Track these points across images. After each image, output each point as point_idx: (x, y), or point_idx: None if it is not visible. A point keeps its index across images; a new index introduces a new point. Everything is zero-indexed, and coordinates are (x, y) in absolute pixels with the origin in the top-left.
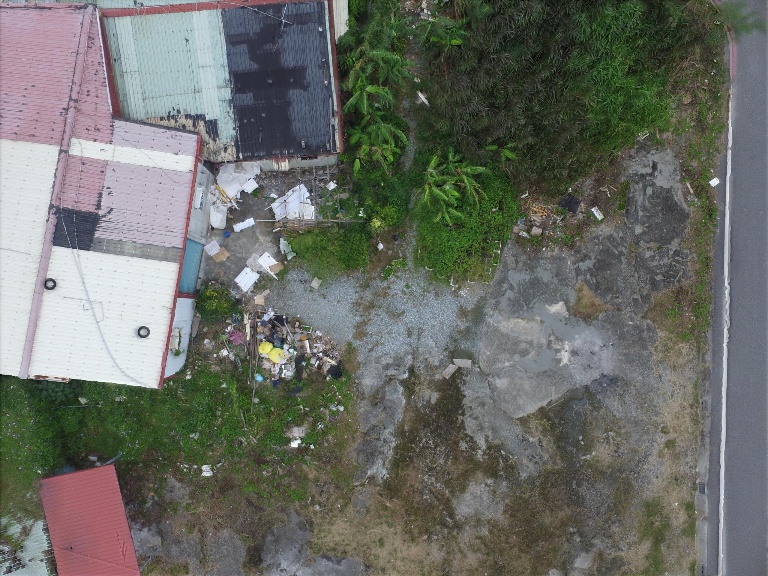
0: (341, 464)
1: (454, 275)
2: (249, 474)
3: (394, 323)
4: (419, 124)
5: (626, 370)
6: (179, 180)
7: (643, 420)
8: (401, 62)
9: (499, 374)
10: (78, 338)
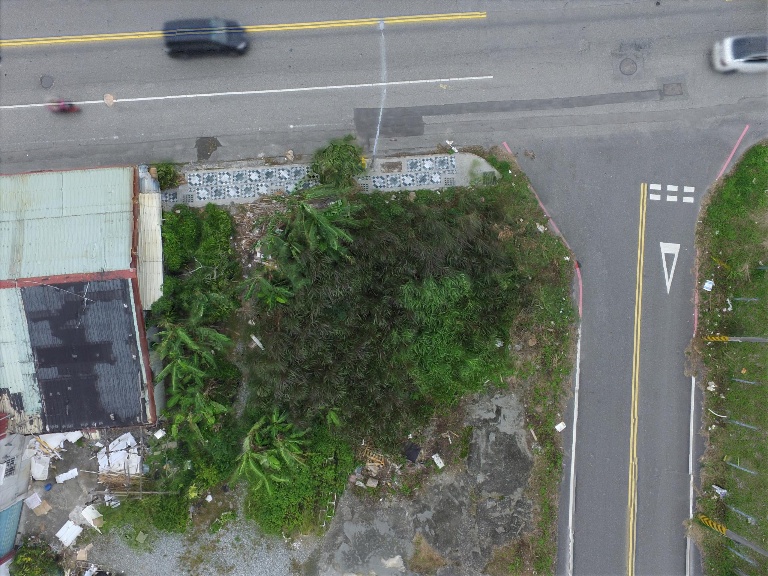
0: None
1: (285, 530)
2: None
3: None
4: (252, 370)
5: None
6: None
7: None
8: (230, 311)
9: None
10: None
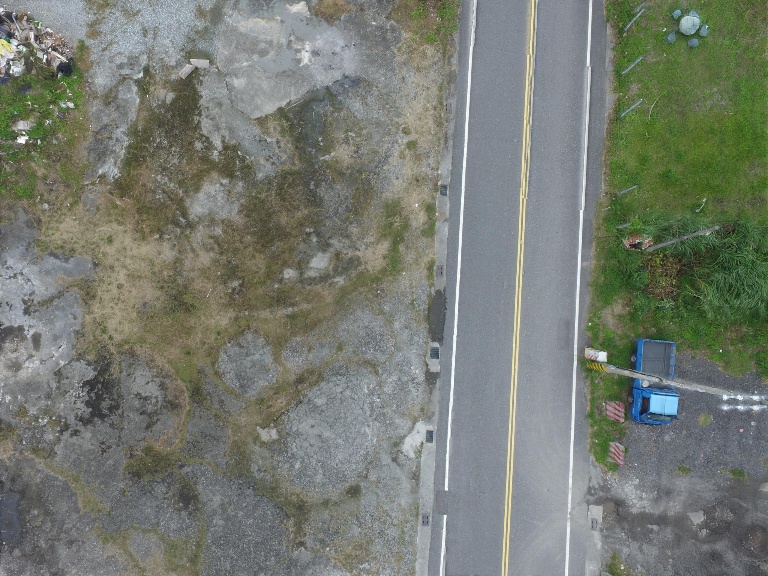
0: (71, 163)
1: None
2: None
3: (129, 22)
4: None
5: (368, 70)
6: None
7: (384, 121)
8: None
9: (237, 74)
10: None
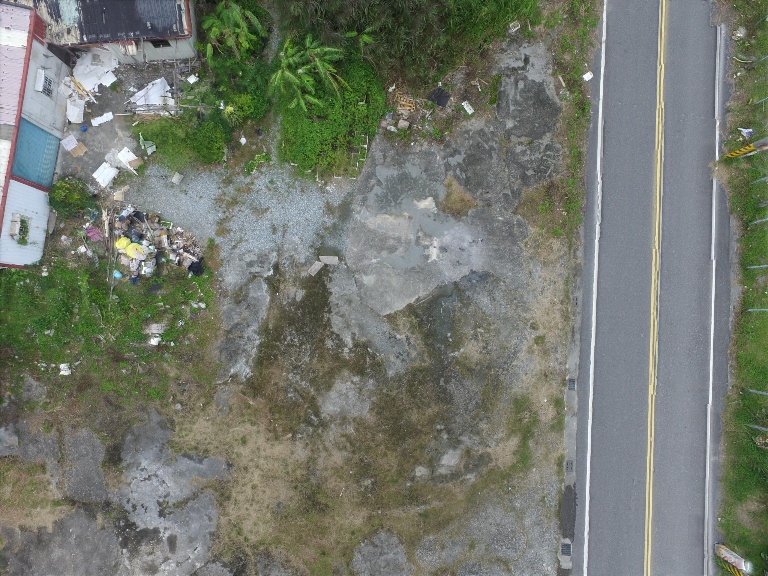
0: (203, 362)
1: (318, 169)
2: (108, 372)
3: (258, 219)
4: (283, 15)
5: (495, 266)
6: (11, 55)
7: (512, 316)
8: None
9: (366, 271)
10: None
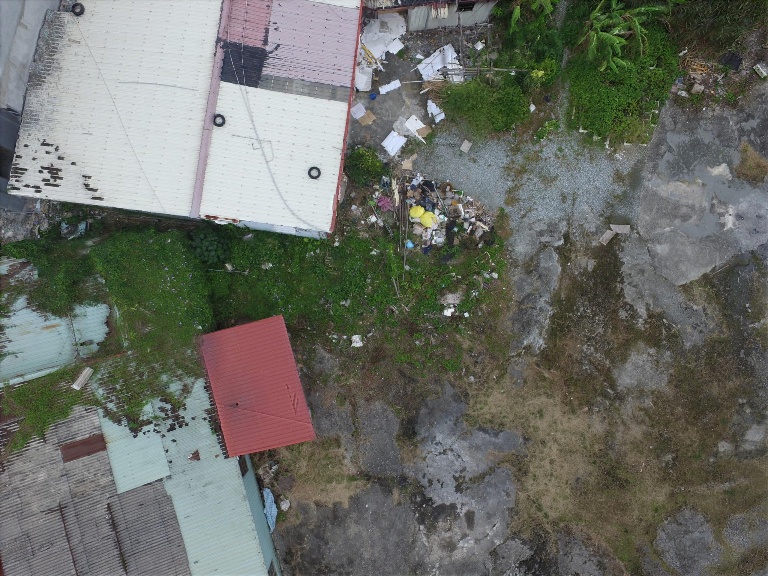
0: (496, 334)
1: (612, 135)
2: (401, 344)
3: (548, 188)
4: None
5: None
6: (345, 16)
7: None
8: None
9: (659, 239)
10: (248, 178)
